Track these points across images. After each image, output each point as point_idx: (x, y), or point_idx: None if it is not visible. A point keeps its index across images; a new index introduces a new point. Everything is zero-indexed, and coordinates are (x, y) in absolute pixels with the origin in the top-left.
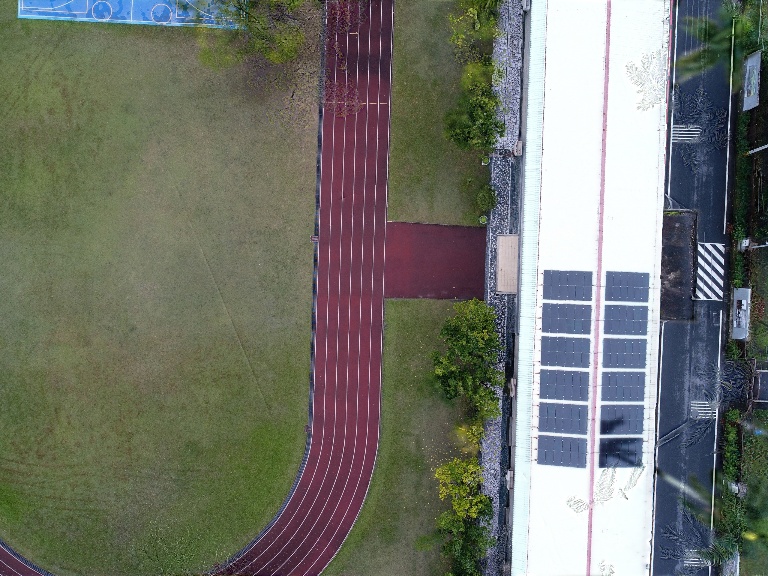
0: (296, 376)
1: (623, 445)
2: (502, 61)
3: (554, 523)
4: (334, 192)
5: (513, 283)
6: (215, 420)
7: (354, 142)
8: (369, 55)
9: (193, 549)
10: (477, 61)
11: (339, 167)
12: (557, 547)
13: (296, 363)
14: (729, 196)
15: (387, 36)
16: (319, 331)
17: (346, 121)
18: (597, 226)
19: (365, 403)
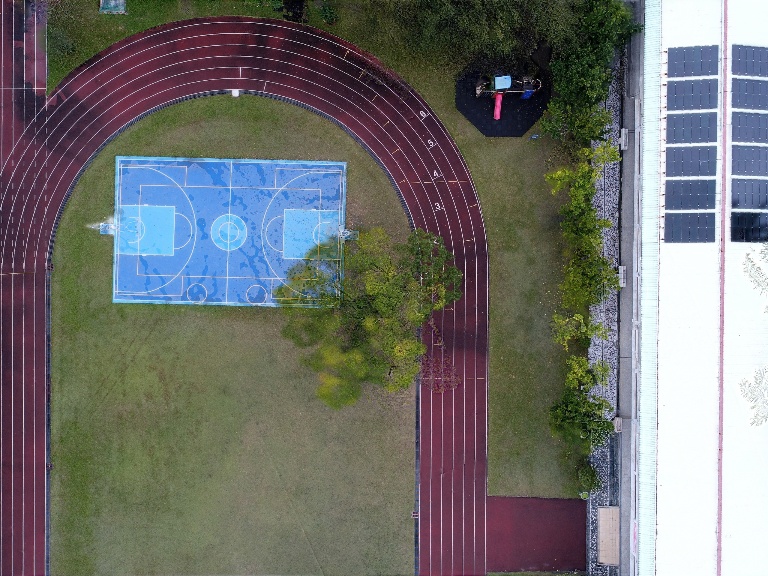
0: None
1: None
2: (598, 334)
3: None
4: (433, 468)
5: (615, 555)
6: None
7: (452, 418)
8: (465, 331)
9: None
10: (573, 335)
11: (438, 443)
12: None
13: None
14: None
15: (483, 312)
16: None
17: (444, 397)
18: (715, 546)
19: None
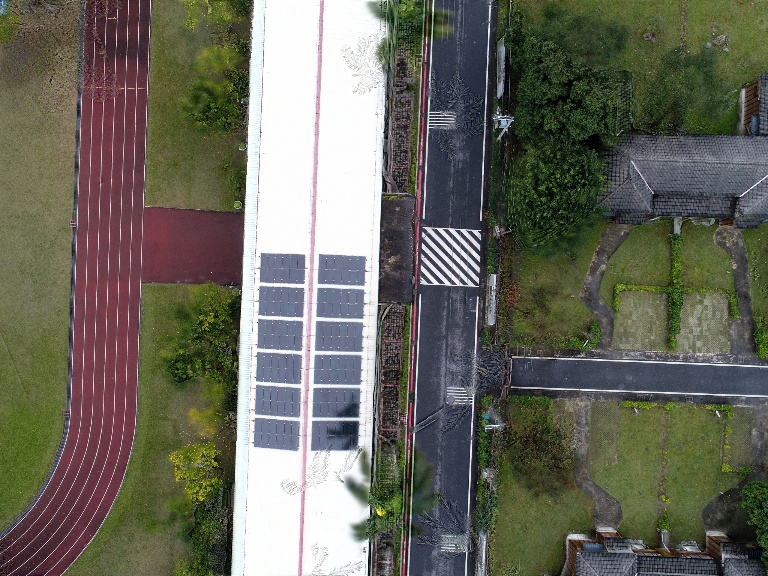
0: (54, 361)
1: (337, 428)
2: None
3: (269, 506)
4: (92, 177)
5: None
6: None
7: (112, 127)
8: (127, 40)
9: None
10: (234, 47)
11: (97, 152)
12: (272, 530)
13: (54, 348)
14: (486, 182)
15: (145, 21)
16: (77, 316)
17: (104, 106)
18: (310, 209)
19: (122, 388)
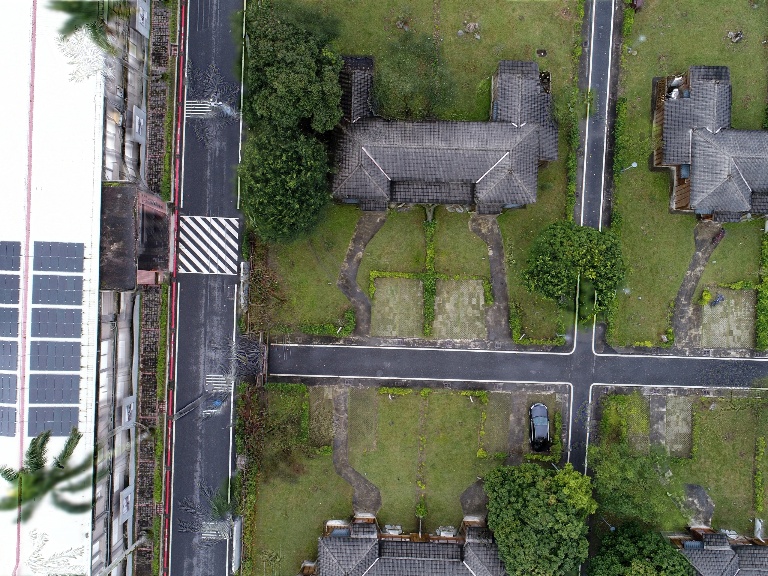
0: None
1: (56, 414)
2: None
3: None
4: None
5: None
6: None
7: None
8: None
9: None
10: None
11: None
12: None
13: None
14: None
15: None
16: None
17: None
18: (24, 196)
19: None
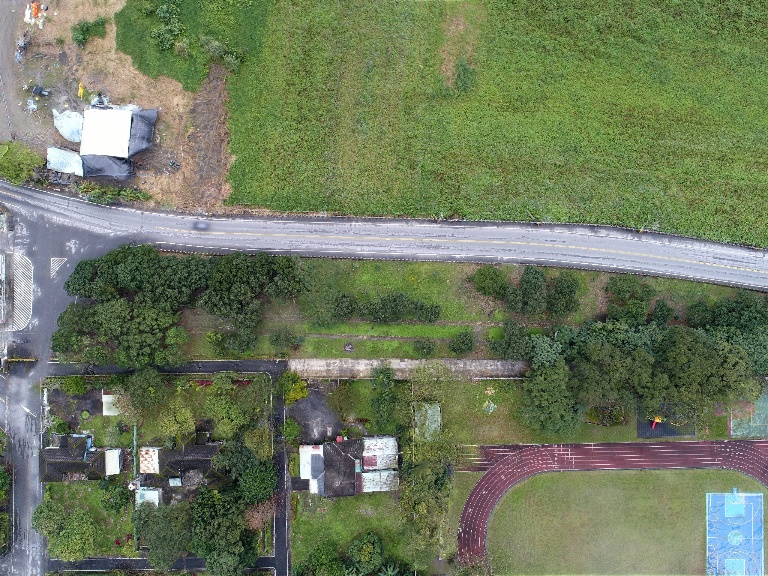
0: None
1: None
2: None
3: None
4: None
5: None
6: None
7: None
8: None
9: (504, 571)
10: None
11: None
12: None
13: None
14: None
15: None
16: None
17: None
18: None
19: None
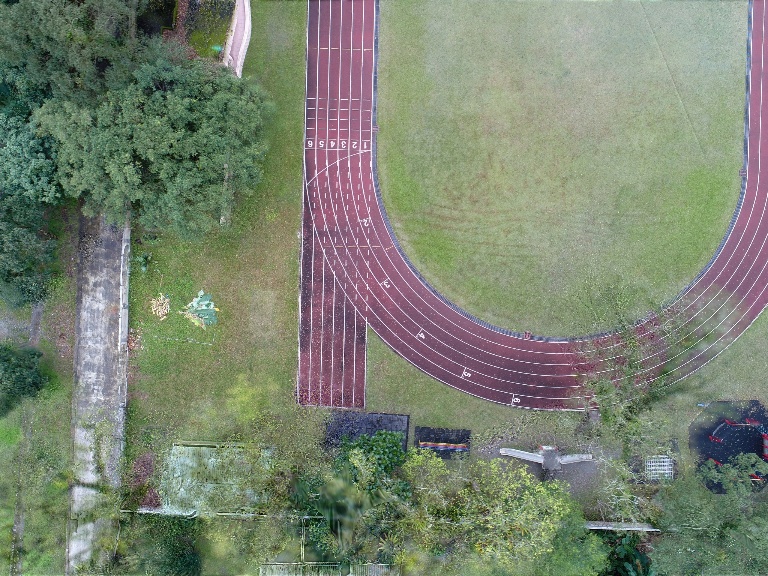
0: (731, 120)
1: None
2: None
3: None
4: None
5: None
6: (650, 164)
7: None
8: None
9: (628, 295)
10: None
11: None
12: None
13: (731, 107)
14: None
15: None
16: (754, 74)
17: None
18: None
19: None
